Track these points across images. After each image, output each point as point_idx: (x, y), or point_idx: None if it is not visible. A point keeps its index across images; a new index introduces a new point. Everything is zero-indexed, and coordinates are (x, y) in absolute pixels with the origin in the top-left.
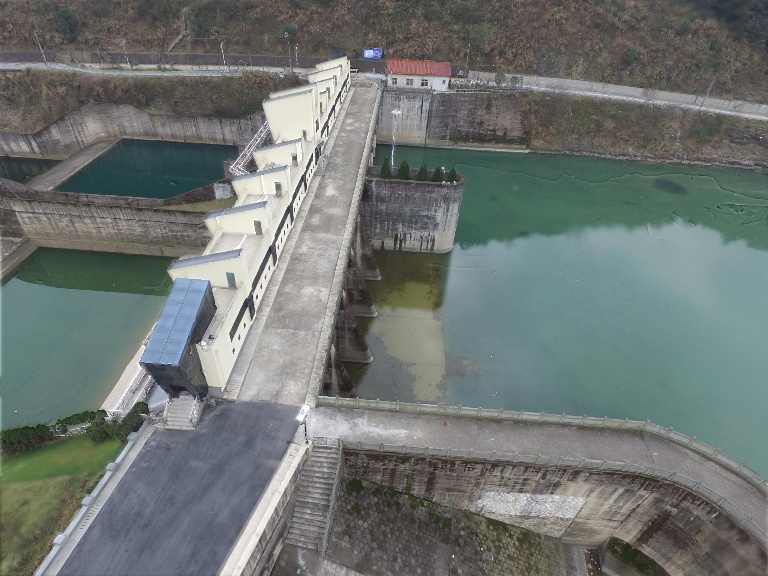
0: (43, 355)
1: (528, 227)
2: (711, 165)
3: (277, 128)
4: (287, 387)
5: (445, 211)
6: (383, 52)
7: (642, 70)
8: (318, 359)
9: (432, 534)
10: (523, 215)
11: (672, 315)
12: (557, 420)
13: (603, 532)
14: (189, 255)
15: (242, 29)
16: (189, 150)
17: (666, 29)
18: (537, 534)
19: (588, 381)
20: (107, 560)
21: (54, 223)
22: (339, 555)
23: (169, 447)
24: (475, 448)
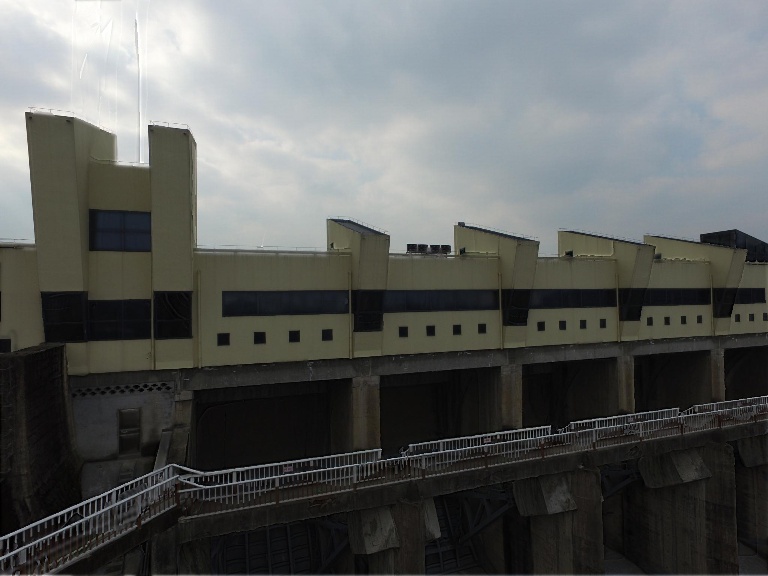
0: None
1: None
2: None
3: None
4: None
5: None
6: None
7: None
8: None
9: None
10: None
11: None
12: None
13: None
14: None
15: None
16: None
17: None
18: None
19: None
20: None
21: None
22: None
23: None
24: None
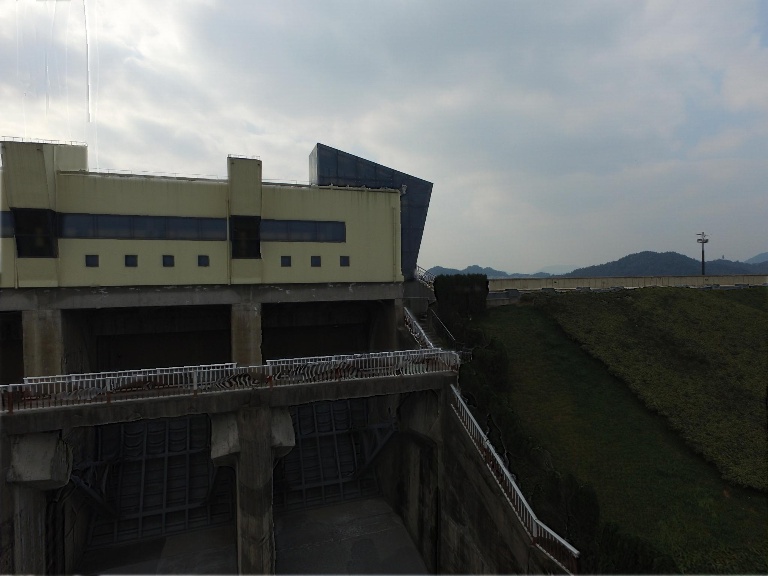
0: None
1: None
2: None
3: None
4: None
5: None
6: None
7: None
8: None
9: None
10: None
11: None
12: None
13: None
14: None
15: None
16: None
17: None
18: None
19: None
20: None
21: None
22: None
23: None
24: None
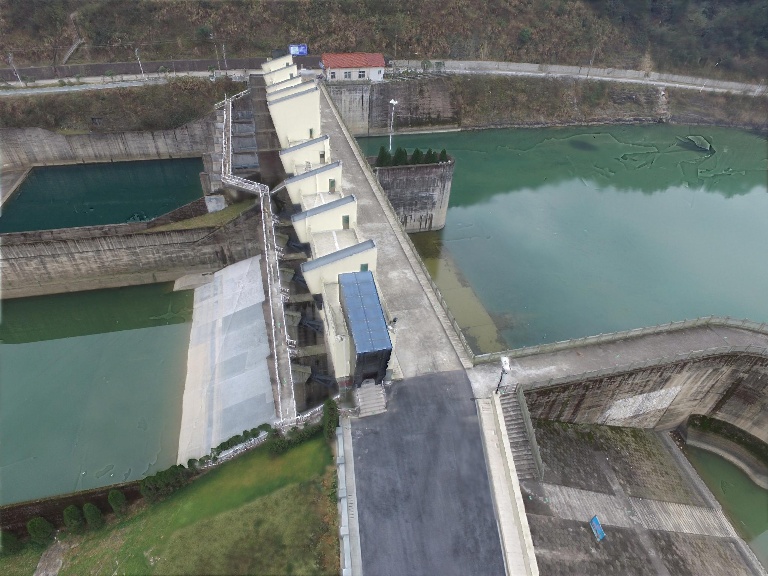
0: (73, 411)
1: (494, 195)
2: (603, 124)
3: (283, 129)
4: (438, 357)
5: (441, 189)
6: (308, 48)
7: (535, 48)
8: (447, 329)
9: (586, 447)
10: (485, 186)
11: (635, 247)
12: (653, 331)
13: (686, 413)
14: (186, 276)
15: (149, 33)
16: (117, 170)
17: (548, 11)
18: (639, 429)
19: (604, 310)
20: (396, 533)
21: (19, 269)
22: (548, 477)
23: (376, 431)
24: (611, 365)
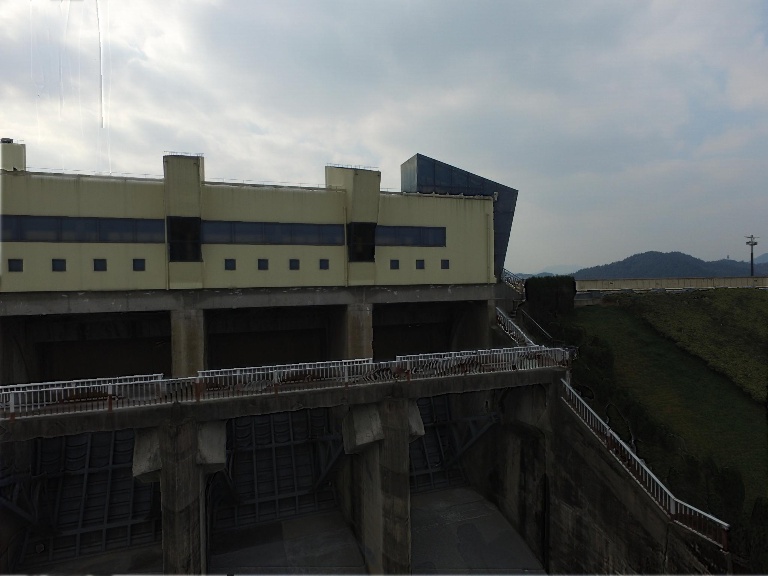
0: None
1: None
2: None
3: None
4: None
5: None
6: None
7: None
8: None
9: None
10: None
11: None
12: None
13: None
14: None
15: None
16: None
17: None
18: None
19: None
20: None
21: None
22: None
23: None
24: None
